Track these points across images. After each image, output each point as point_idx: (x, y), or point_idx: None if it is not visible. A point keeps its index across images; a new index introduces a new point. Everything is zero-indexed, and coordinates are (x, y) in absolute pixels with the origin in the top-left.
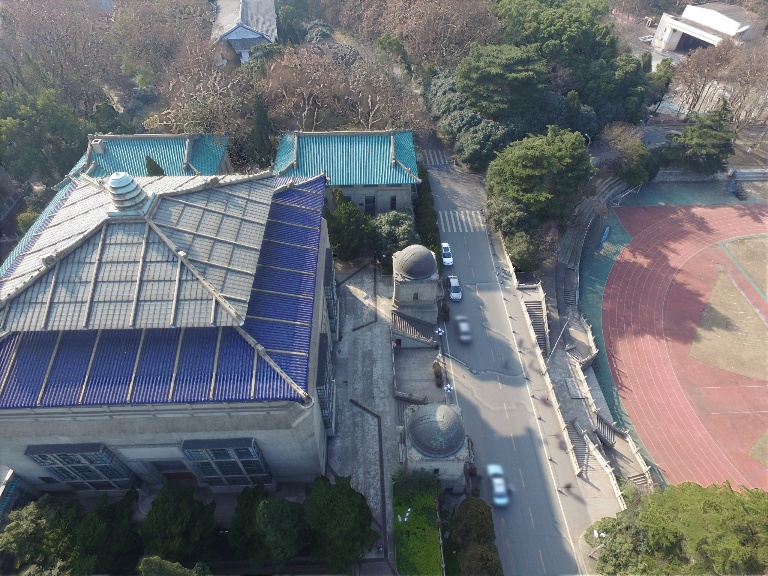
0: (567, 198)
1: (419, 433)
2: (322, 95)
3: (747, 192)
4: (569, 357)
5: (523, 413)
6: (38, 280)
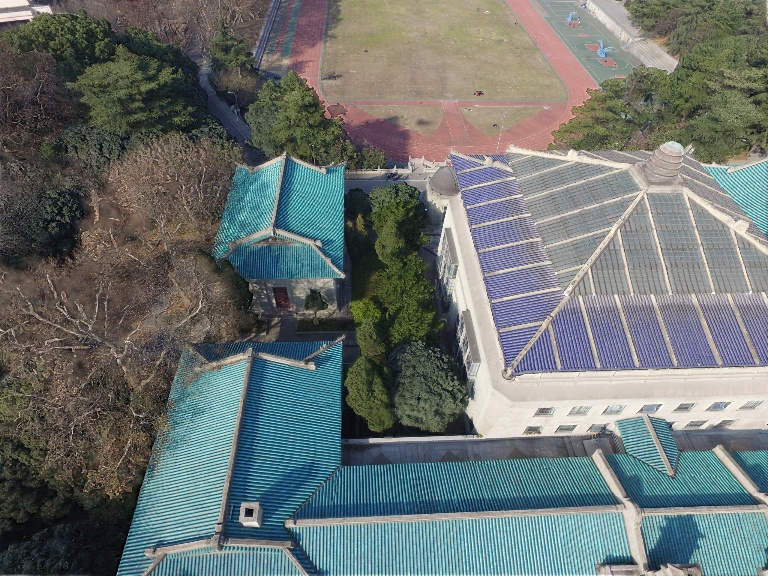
0: None
1: None
2: None
3: None
4: None
5: None
6: None
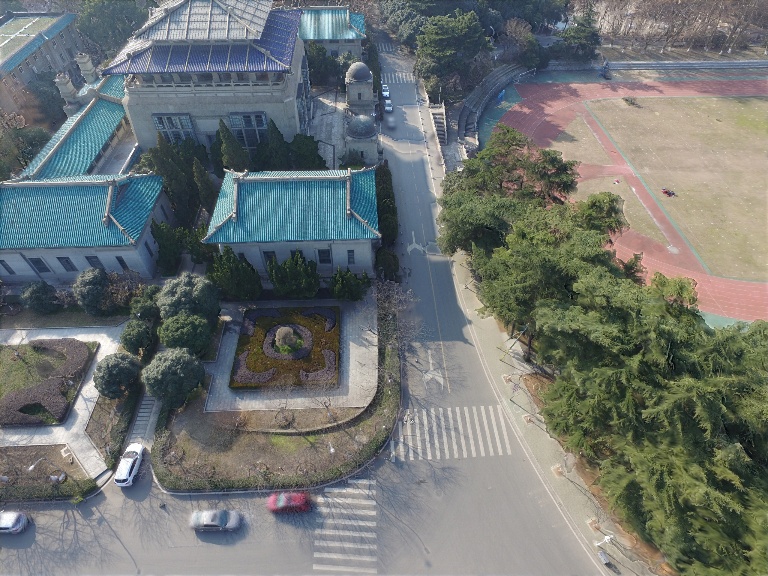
0: (478, 72)
1: (351, 126)
2: (304, 3)
3: (613, 75)
4: (460, 145)
5: (420, 154)
6: (161, 20)
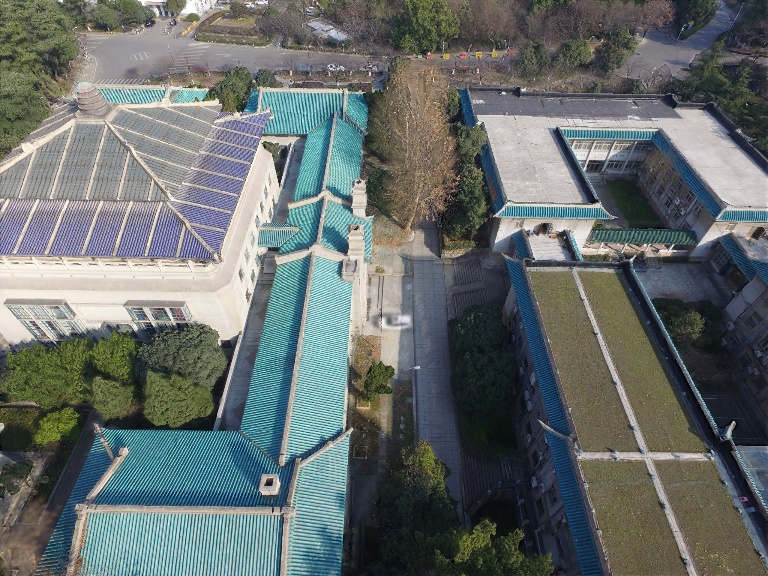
0: None
1: None
2: None
3: None
4: None
5: None
6: None
